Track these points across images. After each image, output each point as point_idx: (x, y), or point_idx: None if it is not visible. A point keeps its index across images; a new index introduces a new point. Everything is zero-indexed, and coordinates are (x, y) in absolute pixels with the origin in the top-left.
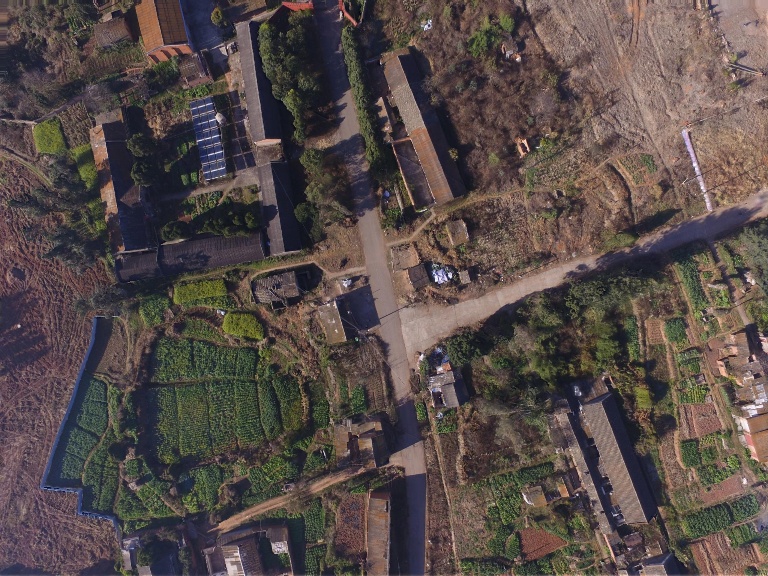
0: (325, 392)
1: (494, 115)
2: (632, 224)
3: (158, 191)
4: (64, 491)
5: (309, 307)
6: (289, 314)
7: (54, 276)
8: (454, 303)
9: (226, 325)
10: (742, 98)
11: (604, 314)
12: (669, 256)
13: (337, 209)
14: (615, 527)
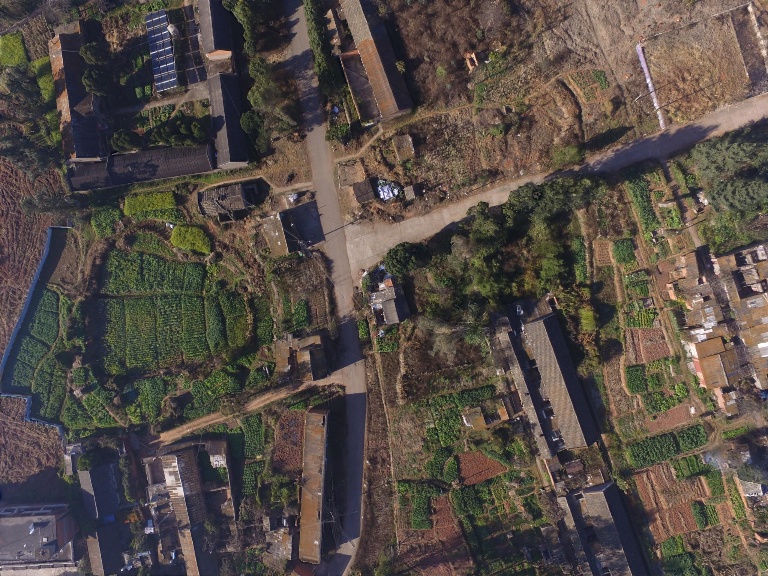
0: (270, 309)
1: (444, 29)
2: (582, 142)
3: (113, 104)
4: (14, 398)
5: (255, 221)
6: (236, 229)
7: (13, 187)
8: (399, 220)
9: (174, 237)
10: (699, 12)
11: (550, 233)
12: (619, 175)
13: (281, 118)
14: (555, 452)
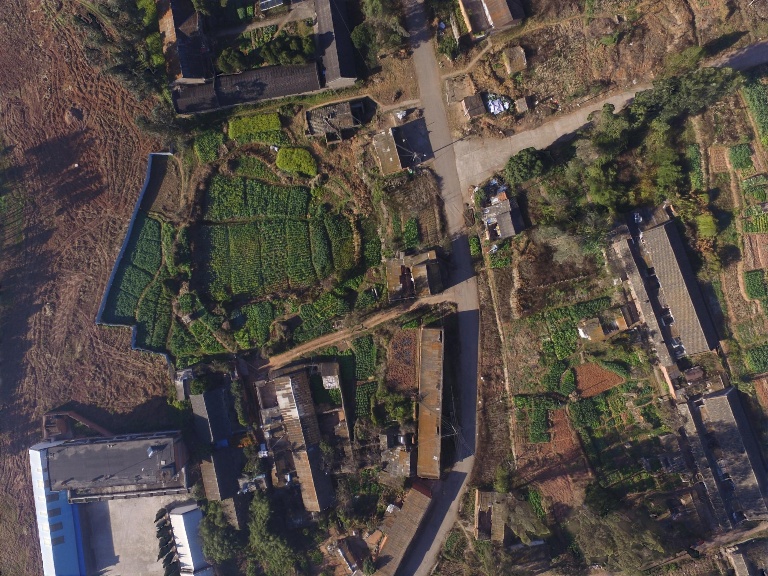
0: (377, 230)
1: None
2: None
3: (214, 27)
4: (118, 329)
5: (363, 140)
6: (342, 150)
7: (111, 115)
8: (510, 135)
9: (280, 159)
10: None
11: None
12: None
13: (395, 30)
14: (675, 359)
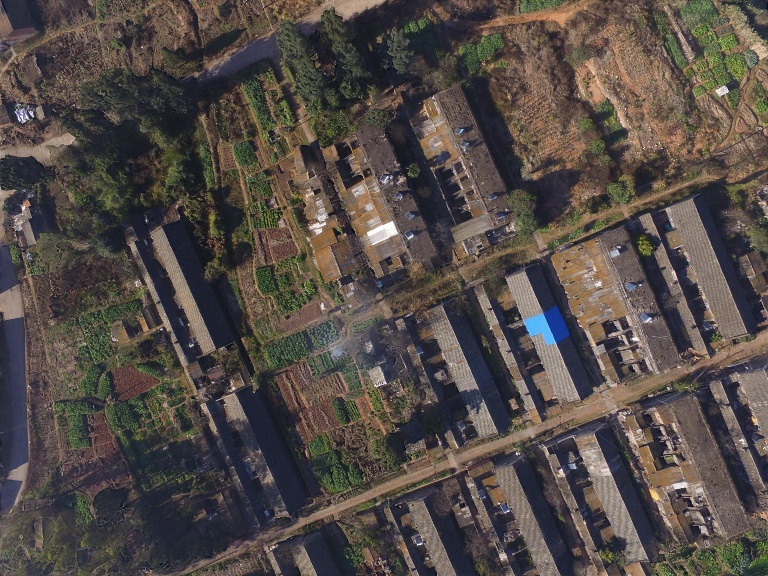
0: None
1: None
2: (199, 48)
3: None
4: None
5: None
6: None
7: None
8: (39, 143)
9: None
10: None
11: None
12: (236, 78)
13: None
14: (194, 359)
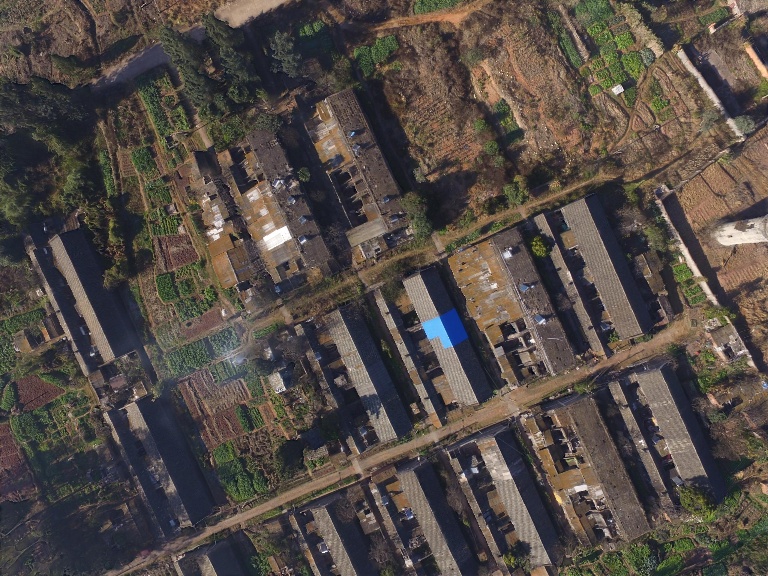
0: None
1: None
2: (96, 54)
3: None
4: None
5: None
6: None
7: None
8: None
9: None
10: None
11: None
12: (134, 84)
13: None
14: (95, 368)
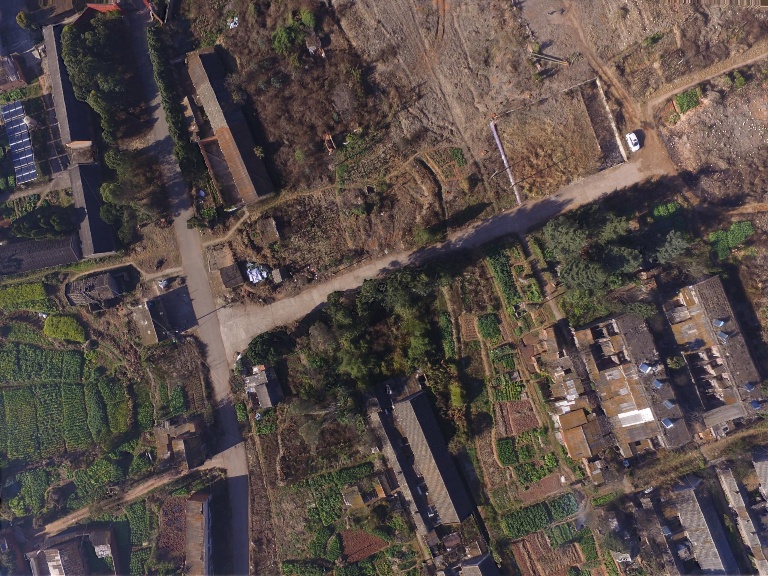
0: (149, 394)
1: (301, 112)
2: (443, 219)
3: None
4: None
5: (126, 309)
6: (110, 316)
7: None
8: (270, 302)
9: (46, 328)
10: (548, 88)
11: None
12: (481, 251)
13: (140, 210)
14: (432, 527)
